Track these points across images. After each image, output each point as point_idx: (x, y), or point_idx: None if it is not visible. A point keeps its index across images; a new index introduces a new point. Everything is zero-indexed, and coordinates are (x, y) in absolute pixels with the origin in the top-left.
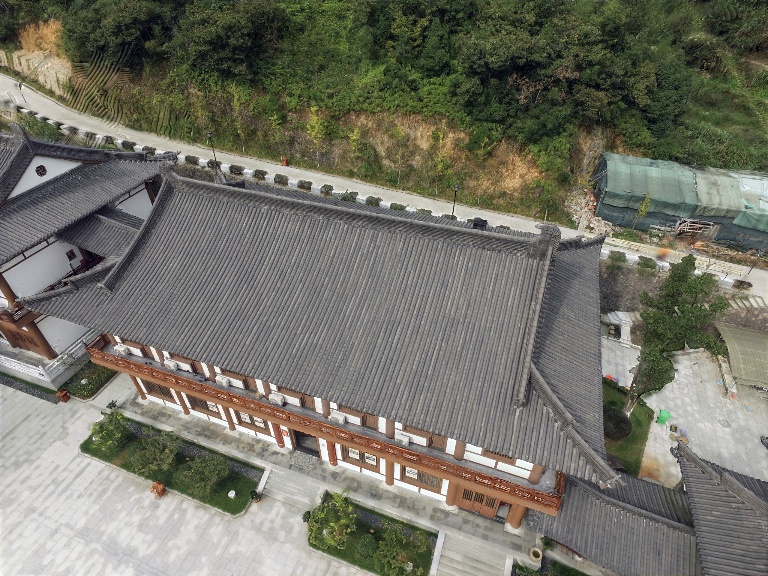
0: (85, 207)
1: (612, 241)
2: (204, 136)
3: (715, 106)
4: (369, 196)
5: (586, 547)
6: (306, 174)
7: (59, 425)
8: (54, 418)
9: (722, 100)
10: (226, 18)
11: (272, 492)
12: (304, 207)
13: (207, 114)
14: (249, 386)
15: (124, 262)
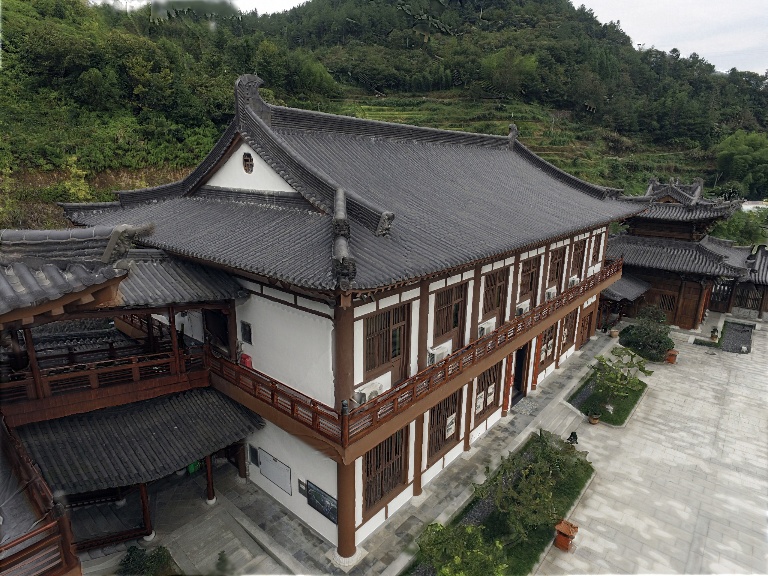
0: None
1: None
2: None
3: None
4: None
5: None
6: None
7: None
8: None
9: None
10: None
11: None
12: (406, 131)
13: None
14: None
15: None
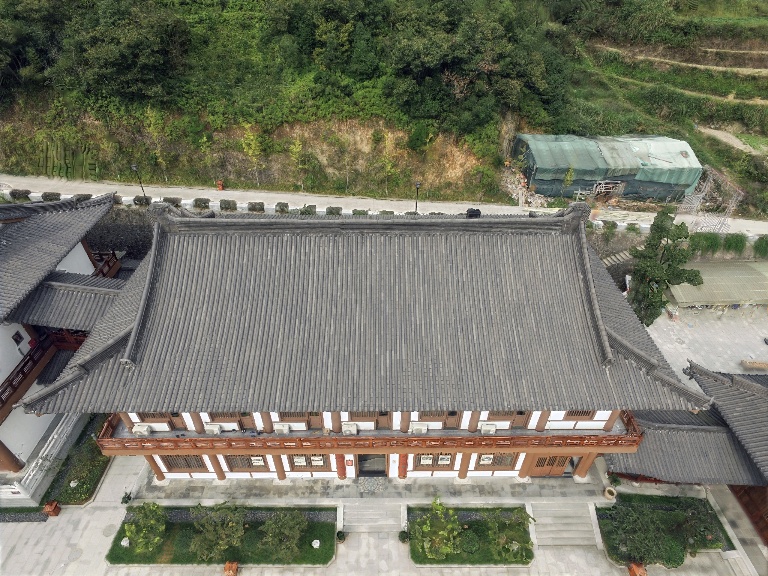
0: (31, 276)
1: (549, 211)
2: (112, 171)
3: (579, 84)
4: (328, 207)
5: (656, 471)
6: (249, 195)
7: (63, 544)
8: (51, 539)
9: (583, 79)
10: (131, 34)
11: (353, 527)
12: (335, 226)
13: (114, 145)
14: (311, 425)
15: (140, 327)
